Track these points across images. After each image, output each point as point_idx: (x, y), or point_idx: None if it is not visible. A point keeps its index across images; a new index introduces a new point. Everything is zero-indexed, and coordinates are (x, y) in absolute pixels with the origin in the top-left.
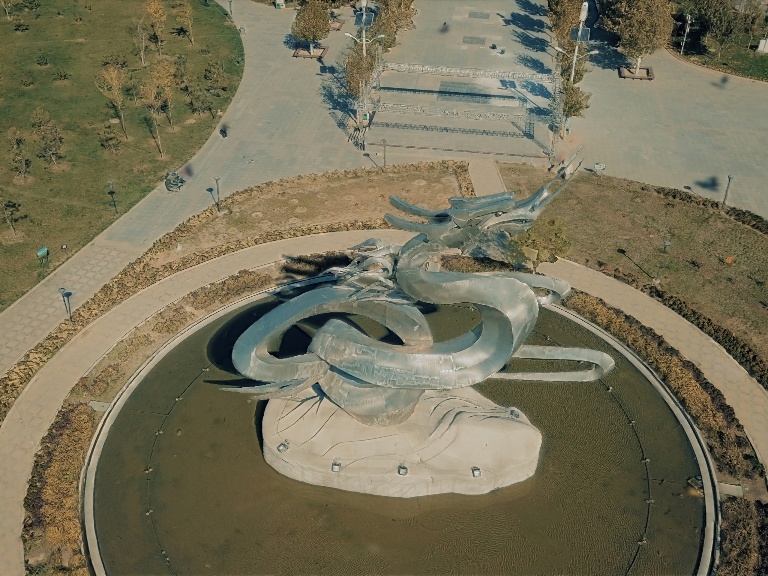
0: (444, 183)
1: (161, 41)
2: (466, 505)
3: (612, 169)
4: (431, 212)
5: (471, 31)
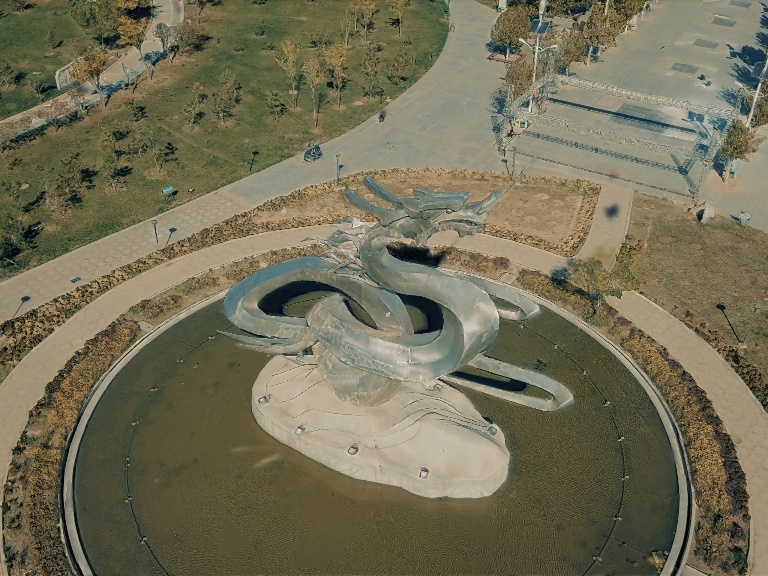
0: (567, 201)
1: (373, 28)
2: (414, 504)
3: (763, 222)
4: (398, 199)
5: (687, 58)
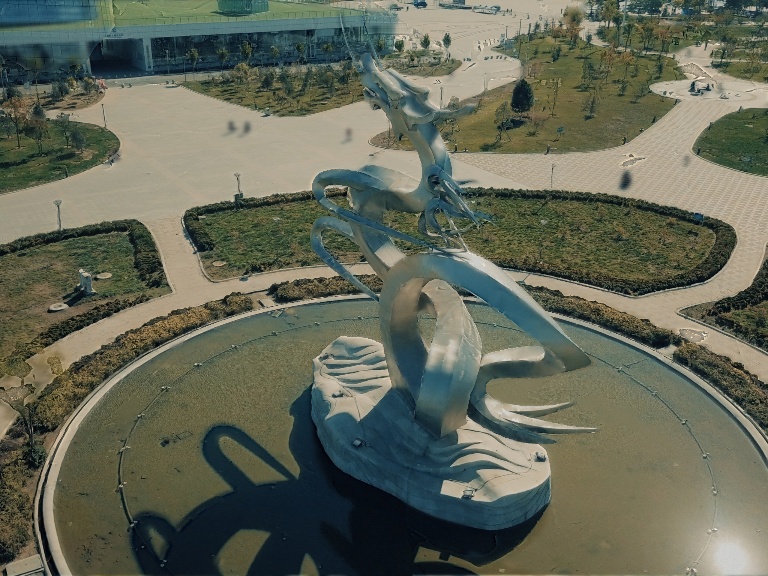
0: None
1: None
2: None
3: None
4: None
5: None
